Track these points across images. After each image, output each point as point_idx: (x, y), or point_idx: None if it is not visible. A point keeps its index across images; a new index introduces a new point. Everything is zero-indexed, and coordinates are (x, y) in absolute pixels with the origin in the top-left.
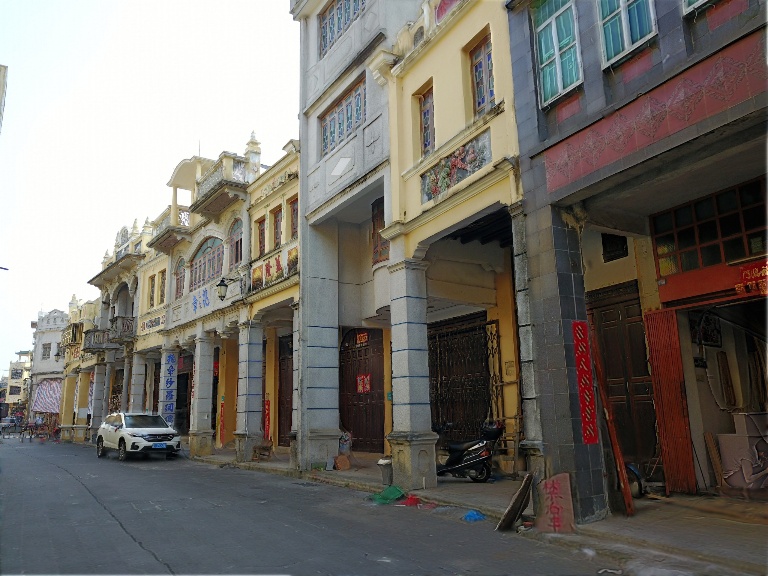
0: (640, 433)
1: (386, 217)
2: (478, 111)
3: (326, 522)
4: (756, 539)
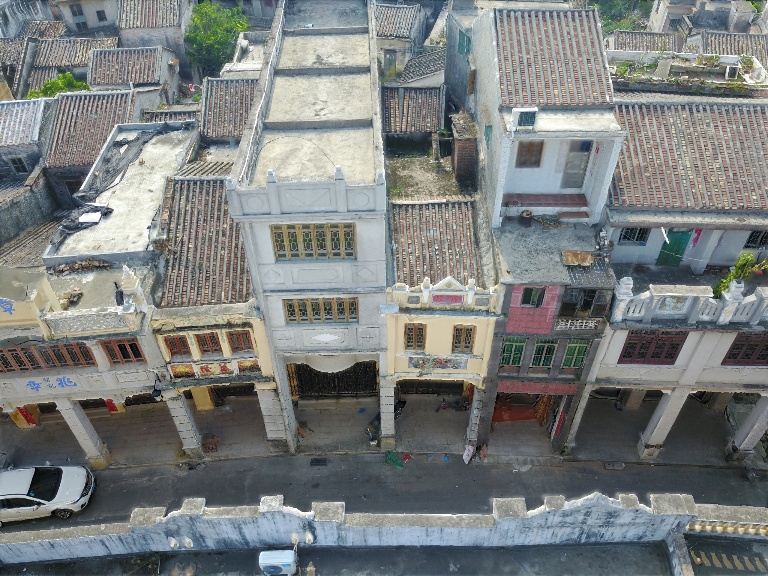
0: (454, 383)
1: (382, 371)
2: (456, 346)
3: (426, 497)
4: (520, 434)
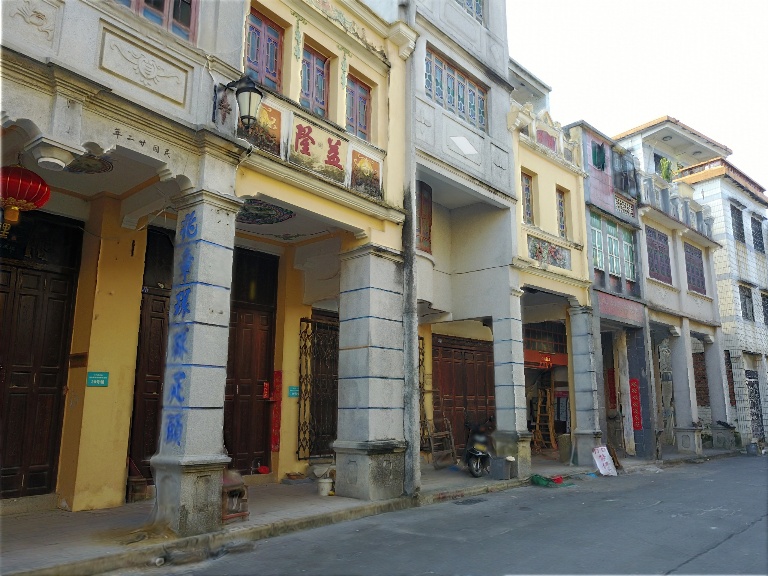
0: None
1: (514, 247)
2: None
3: None
4: None
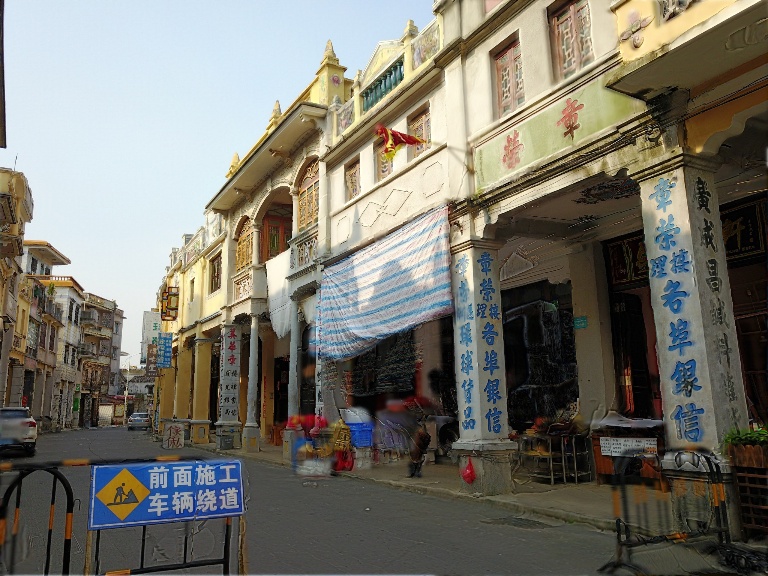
0: None
1: None
2: None
3: None
4: None
